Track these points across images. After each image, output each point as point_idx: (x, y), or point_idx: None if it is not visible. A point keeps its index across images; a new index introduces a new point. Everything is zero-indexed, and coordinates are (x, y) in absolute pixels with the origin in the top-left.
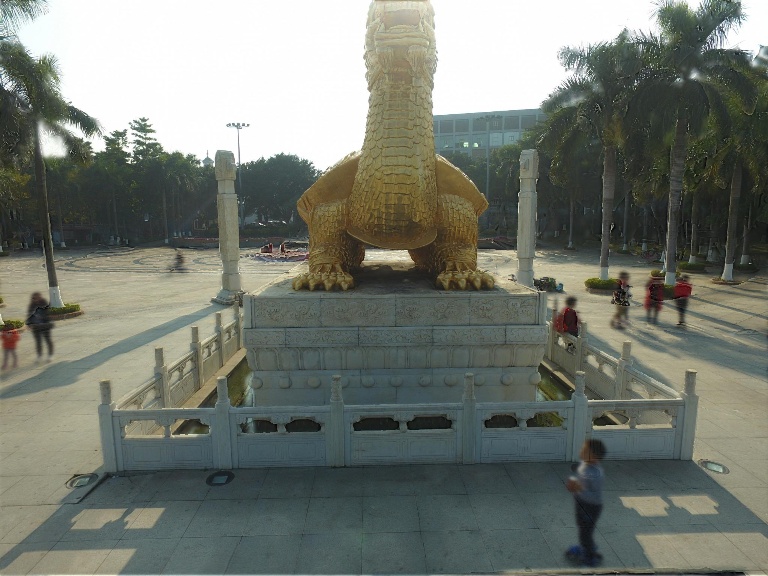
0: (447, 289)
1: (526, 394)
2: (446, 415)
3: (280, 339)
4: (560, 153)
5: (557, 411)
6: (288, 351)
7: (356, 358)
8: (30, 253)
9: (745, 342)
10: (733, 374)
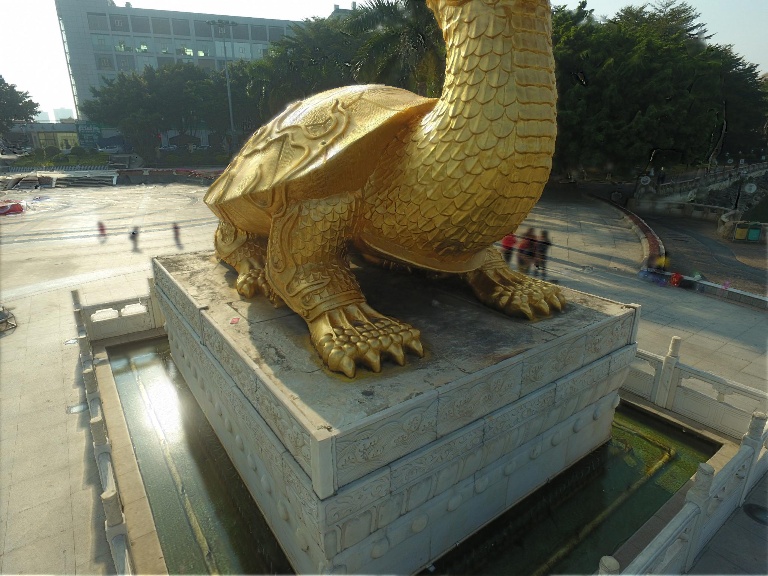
0: (532, 318)
1: (607, 421)
2: (686, 530)
3: (382, 488)
4: None
5: (744, 464)
6: (391, 500)
7: (475, 462)
8: None
9: (603, 282)
10: (648, 325)
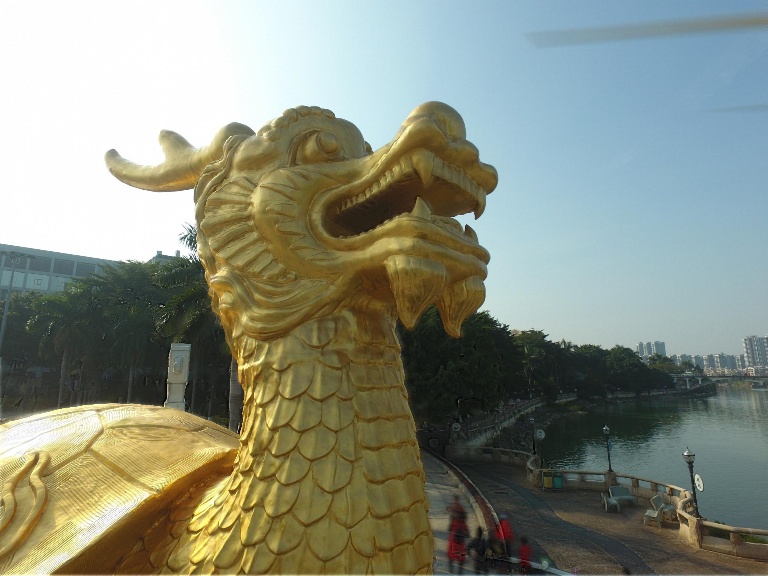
0: None
1: None
2: None
3: None
4: (184, 338)
5: None
6: None
7: None
8: None
9: None
10: None
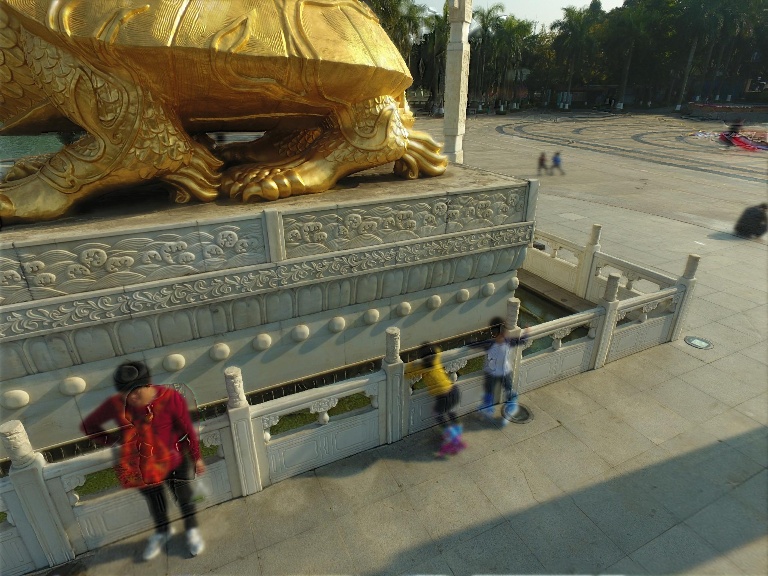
0: None
1: None
2: None
3: None
4: None
5: None
6: None
7: None
8: (519, 113)
9: None
10: None
